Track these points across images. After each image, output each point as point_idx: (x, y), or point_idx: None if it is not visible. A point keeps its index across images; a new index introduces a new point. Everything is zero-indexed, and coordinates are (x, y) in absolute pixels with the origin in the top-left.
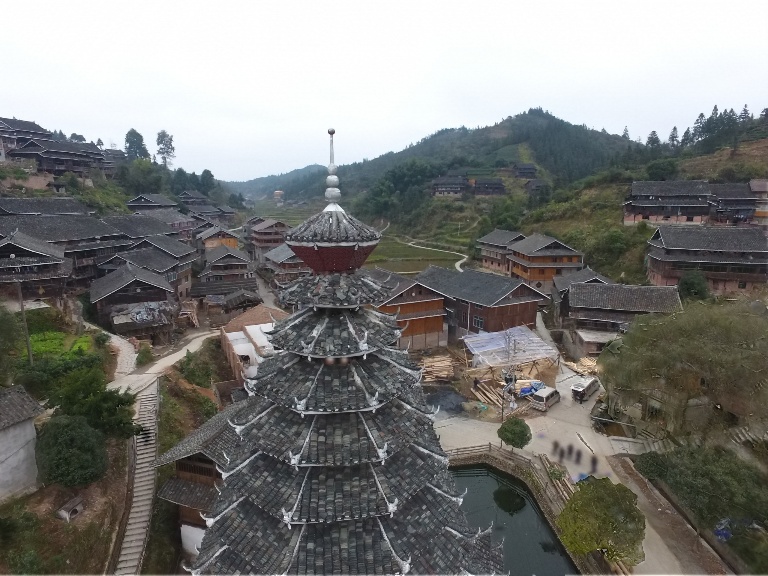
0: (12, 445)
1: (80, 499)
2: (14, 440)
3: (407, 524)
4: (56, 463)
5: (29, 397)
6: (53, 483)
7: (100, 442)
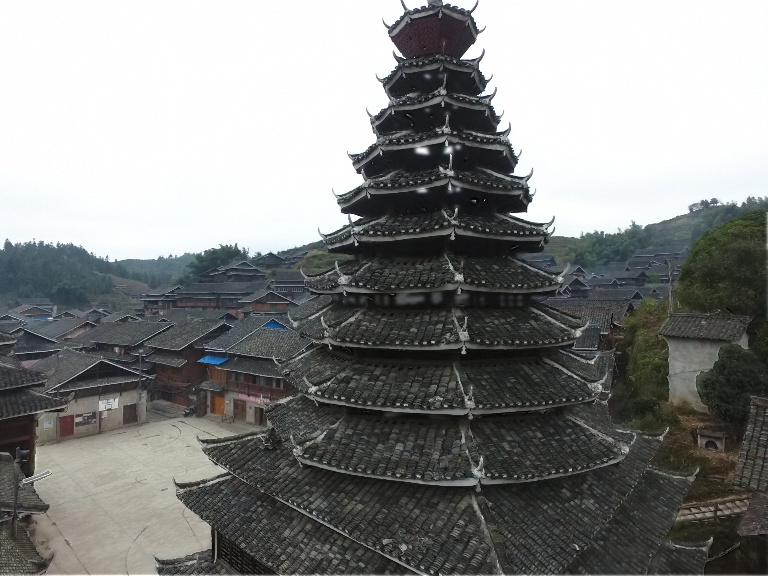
0: (707, 361)
1: (720, 435)
2: (709, 357)
3: (338, 275)
4: (705, 382)
5: (742, 327)
6: (705, 404)
7: (766, 392)
